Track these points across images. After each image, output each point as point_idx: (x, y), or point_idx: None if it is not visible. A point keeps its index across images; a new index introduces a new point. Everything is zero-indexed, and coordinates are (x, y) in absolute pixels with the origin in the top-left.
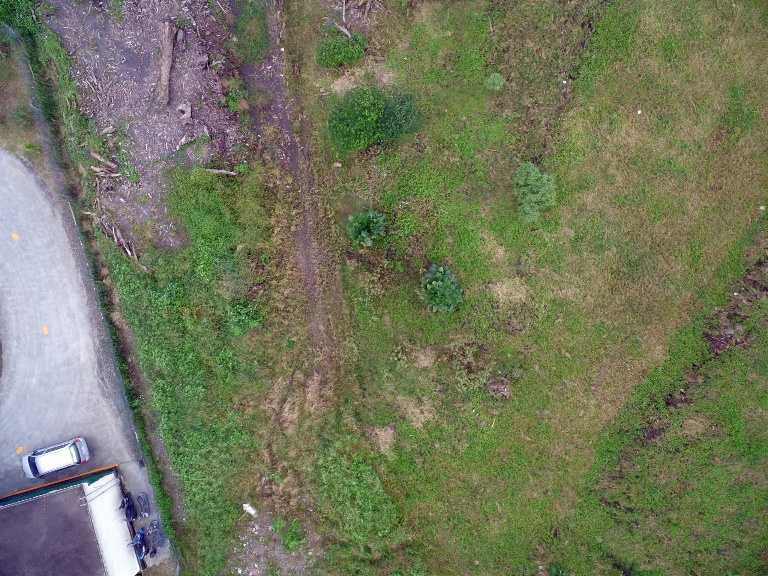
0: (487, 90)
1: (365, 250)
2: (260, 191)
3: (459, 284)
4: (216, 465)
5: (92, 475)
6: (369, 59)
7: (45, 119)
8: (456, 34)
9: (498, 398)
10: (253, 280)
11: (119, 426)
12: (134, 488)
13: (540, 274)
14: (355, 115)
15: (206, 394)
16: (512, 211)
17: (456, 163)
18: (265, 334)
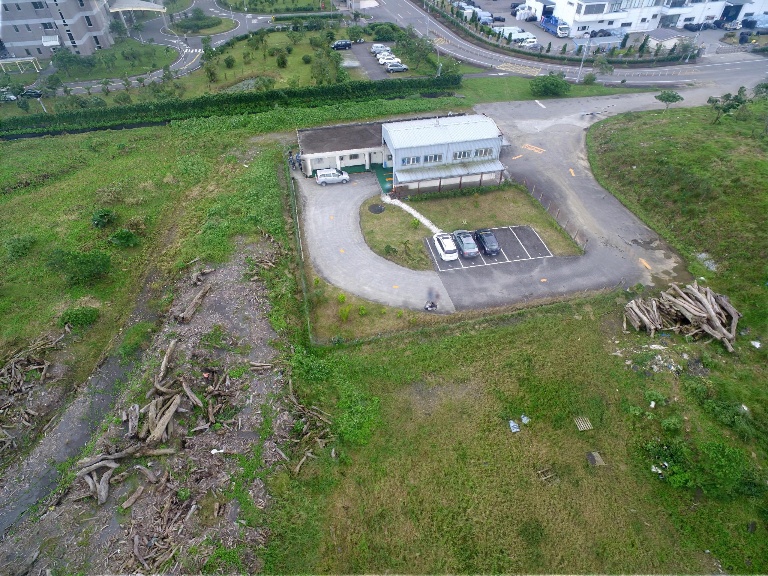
0: None
1: (131, 230)
2: None
3: None
4: None
5: None
6: None
7: None
8: None
9: None
10: None
11: None
12: None
13: None
14: None
15: None
16: None
17: None
18: None
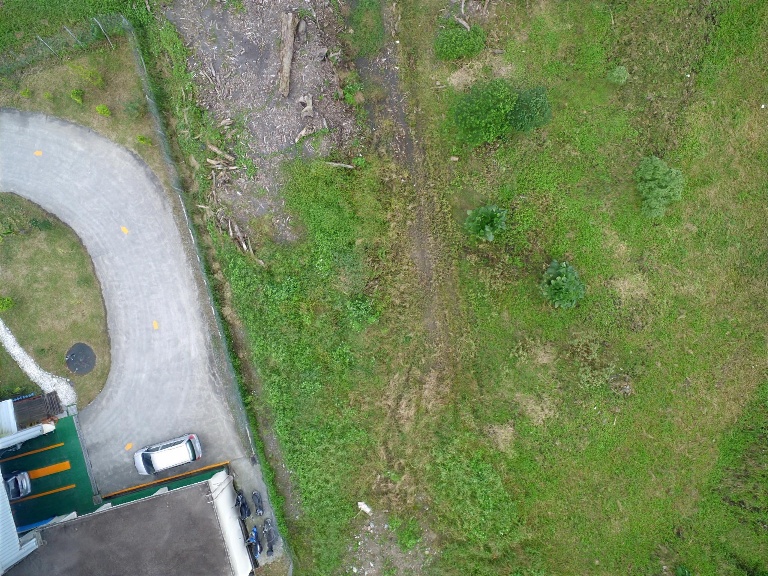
0: (609, 83)
1: (486, 245)
2: (376, 185)
3: (580, 280)
4: (333, 462)
5: (202, 472)
6: (488, 52)
7: (157, 111)
8: (576, 27)
9: (620, 395)
10: (369, 275)
11: (230, 422)
12: (246, 485)
13: (662, 270)
14: (486, 107)
15: (322, 390)
16: (634, 206)
17: (577, 157)
18: (382, 330)
